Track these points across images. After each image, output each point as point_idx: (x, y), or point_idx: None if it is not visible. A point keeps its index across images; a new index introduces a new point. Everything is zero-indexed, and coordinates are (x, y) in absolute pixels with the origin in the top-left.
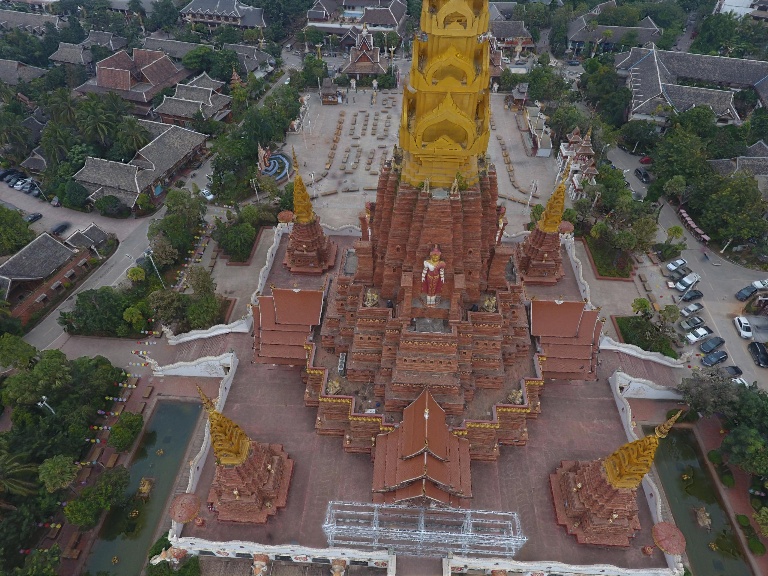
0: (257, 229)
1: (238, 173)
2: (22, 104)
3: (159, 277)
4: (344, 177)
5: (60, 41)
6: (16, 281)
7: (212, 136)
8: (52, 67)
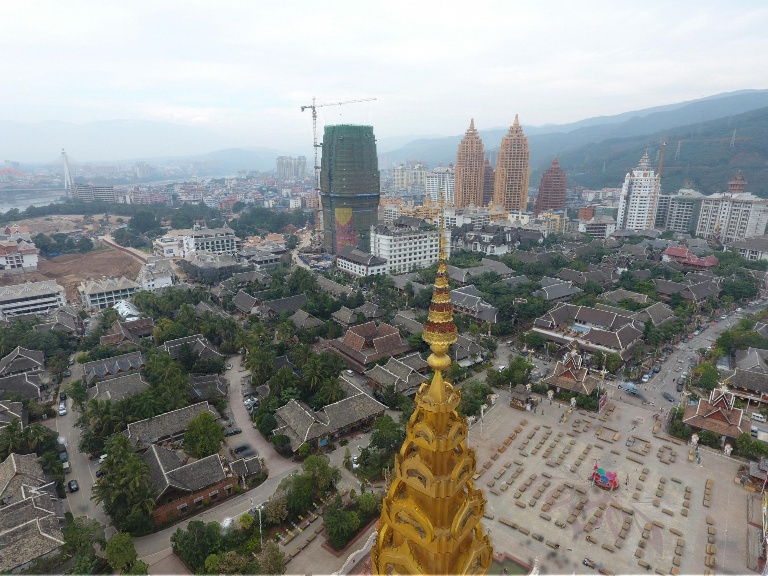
0: (370, 519)
1: (390, 452)
2: (292, 343)
3: (260, 532)
4: (486, 496)
5: (343, 305)
6: (172, 487)
7: (395, 407)
8: (330, 320)
